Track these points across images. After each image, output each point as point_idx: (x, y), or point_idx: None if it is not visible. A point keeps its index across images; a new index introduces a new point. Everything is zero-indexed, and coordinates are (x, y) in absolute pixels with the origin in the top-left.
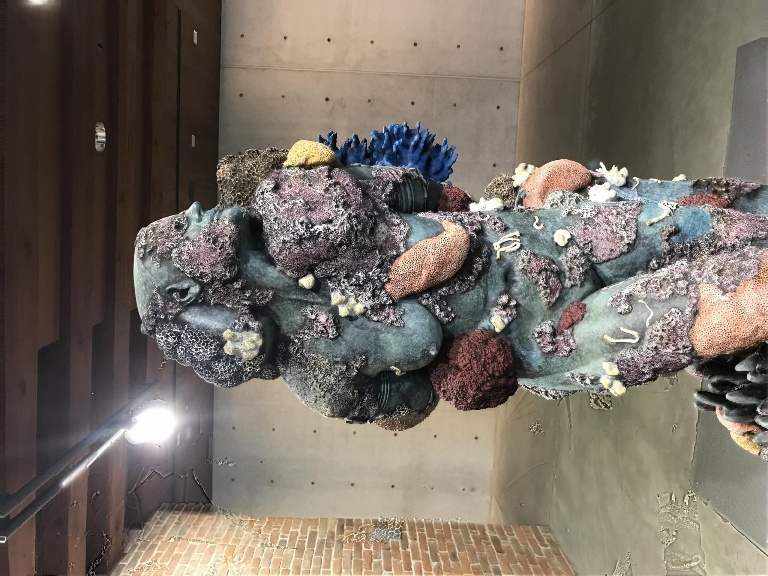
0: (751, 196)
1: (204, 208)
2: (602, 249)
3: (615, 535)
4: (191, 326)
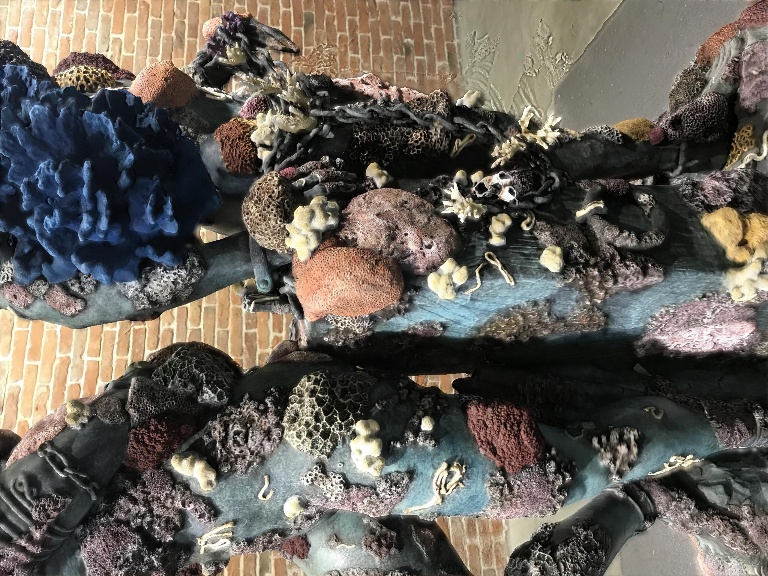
0: (639, 290)
1: None
2: None
3: (494, 9)
4: None
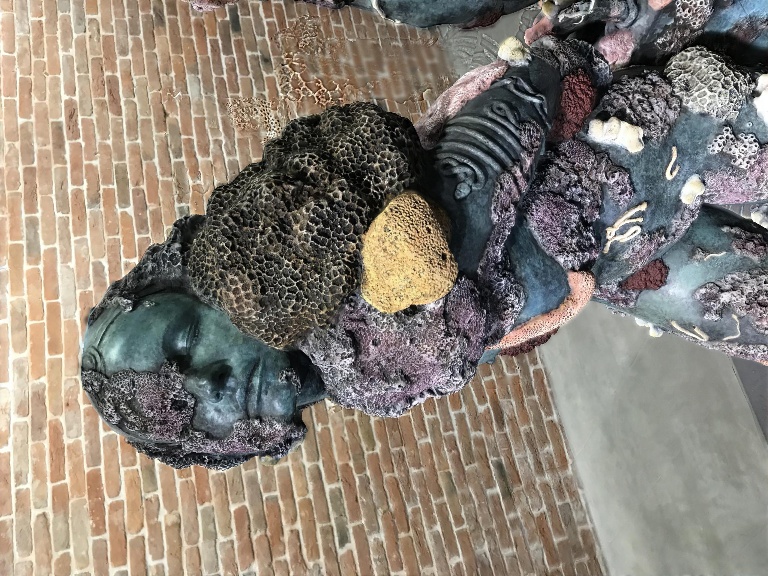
0: None
1: (220, 379)
2: (727, 199)
3: None
4: (213, 458)
